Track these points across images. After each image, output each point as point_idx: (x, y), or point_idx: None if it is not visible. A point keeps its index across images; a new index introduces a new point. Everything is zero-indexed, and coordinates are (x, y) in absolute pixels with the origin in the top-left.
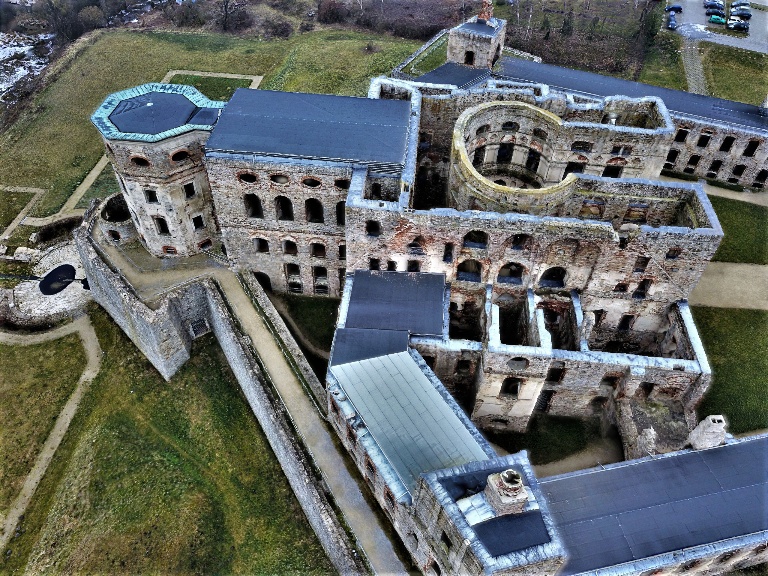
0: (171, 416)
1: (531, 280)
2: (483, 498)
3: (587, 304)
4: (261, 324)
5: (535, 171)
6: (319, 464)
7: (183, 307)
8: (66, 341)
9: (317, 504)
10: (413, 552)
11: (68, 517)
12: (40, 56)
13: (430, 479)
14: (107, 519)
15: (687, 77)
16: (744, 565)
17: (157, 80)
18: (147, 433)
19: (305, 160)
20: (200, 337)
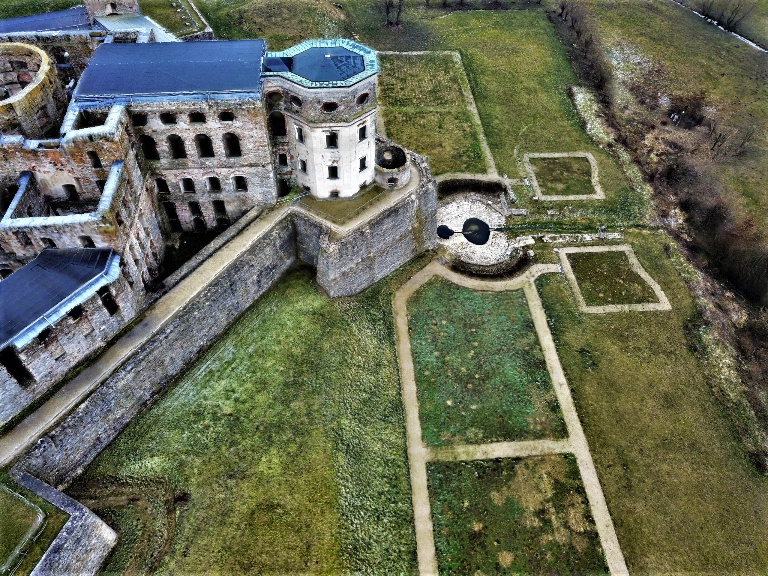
0: None
1: None
2: None
3: None
4: None
5: None
6: None
7: None
8: None
9: None
10: None
11: None
12: None
13: None
14: None
15: None
16: None
17: None
18: None
19: None
20: None
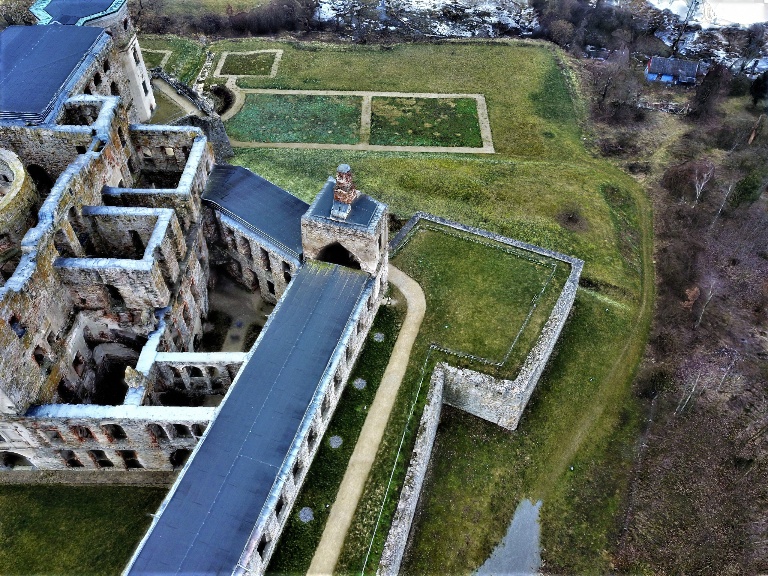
0: None
1: None
2: None
3: None
4: None
5: None
6: None
7: None
8: None
9: None
10: None
11: None
12: (500, 34)
13: None
14: None
15: None
16: None
17: (459, 91)
18: None
19: None
20: None
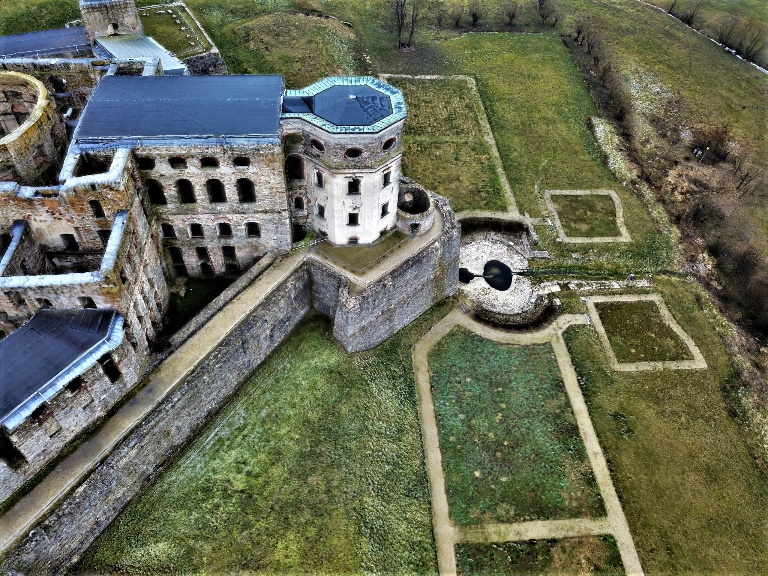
0: None
1: None
2: None
3: None
4: None
5: None
6: None
7: None
8: None
9: None
10: None
11: None
12: None
13: None
14: None
15: None
16: None
17: None
18: None
19: None
20: None
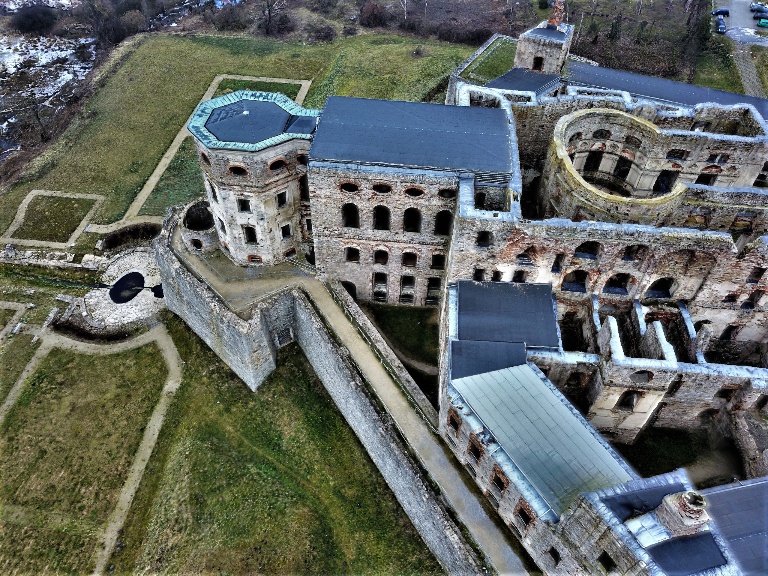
0: (262, 427)
1: (639, 291)
2: (654, 519)
3: (692, 314)
4: (356, 334)
5: (622, 179)
6: (435, 478)
7: (272, 317)
8: (145, 350)
9: (440, 520)
10: (548, 570)
11: (171, 531)
12: (83, 60)
13: (592, 498)
14: (213, 534)
15: (742, 81)
16: None
17: (205, 85)
18: (239, 445)
19: (411, 169)
20: (284, 347)
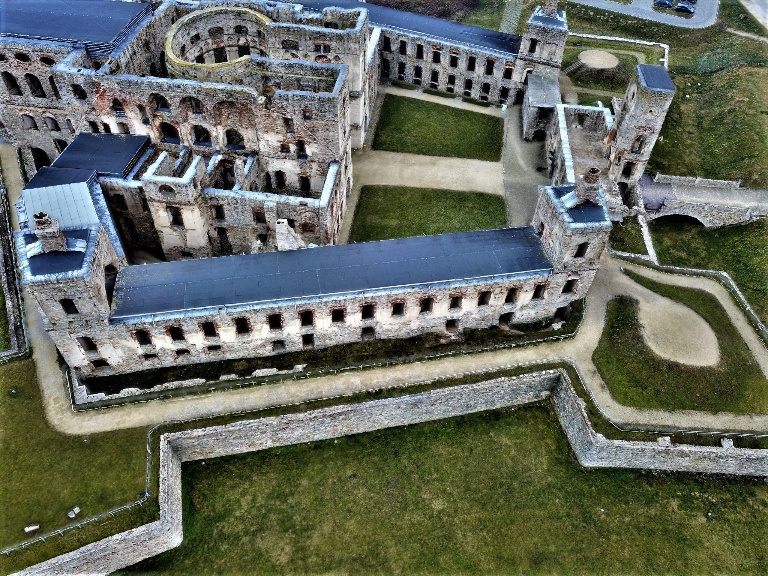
0: None
1: (215, 142)
2: None
3: (267, 165)
4: (20, 182)
5: None
6: None
7: None
8: None
9: (5, 294)
10: None
11: None
12: None
13: (18, 235)
14: None
15: (502, 22)
16: (320, 345)
17: None
18: None
19: (37, 40)
20: None
